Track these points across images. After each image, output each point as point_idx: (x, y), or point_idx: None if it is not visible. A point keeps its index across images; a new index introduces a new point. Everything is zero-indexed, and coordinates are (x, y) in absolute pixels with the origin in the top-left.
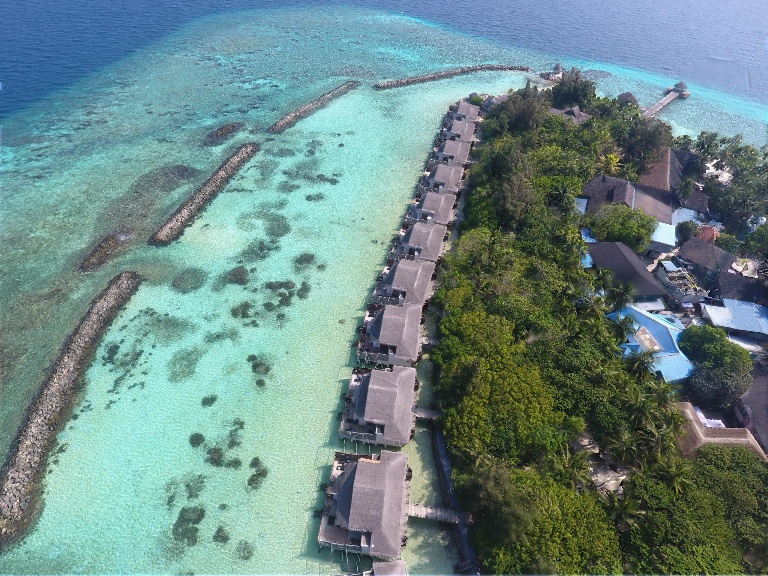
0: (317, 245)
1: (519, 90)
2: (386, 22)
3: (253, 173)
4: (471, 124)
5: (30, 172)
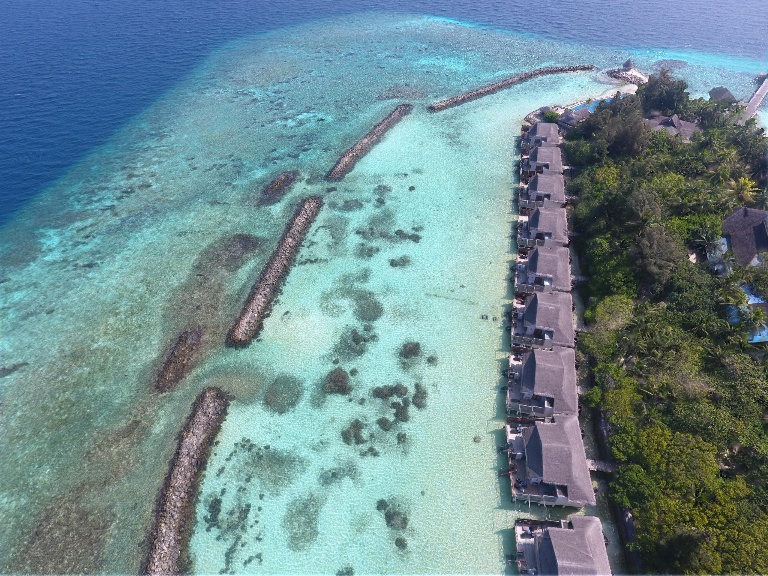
0: (419, 329)
1: (608, 103)
2: (420, 27)
3: (323, 236)
4: (556, 149)
5: (80, 260)
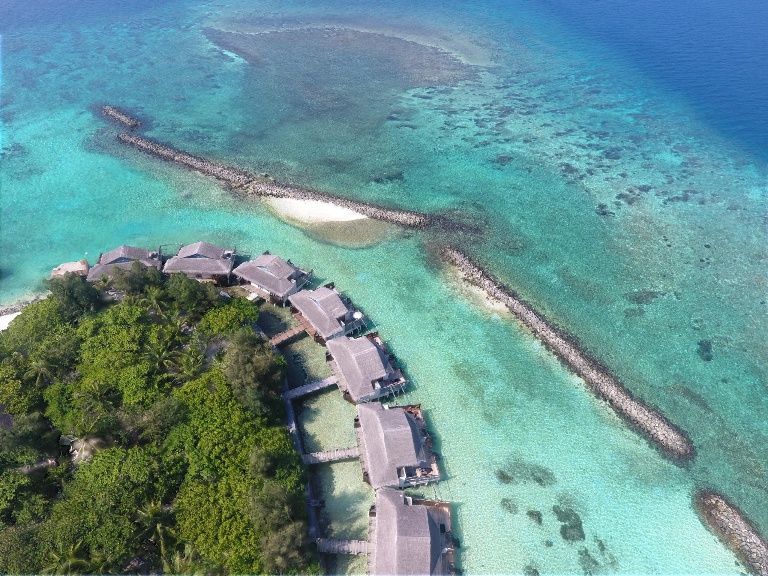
0: None
1: None
2: None
3: None
4: None
5: None
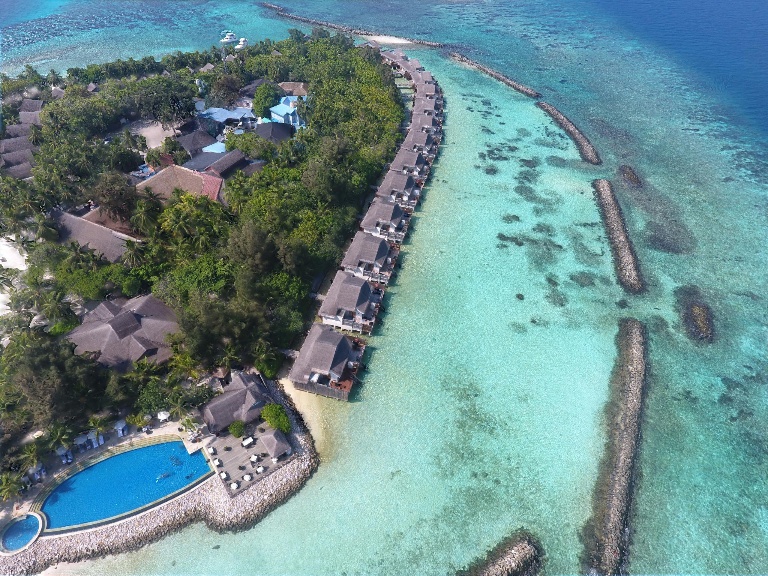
0: (488, 180)
1: (226, 312)
2: None
3: (593, 245)
4: (328, 306)
5: None
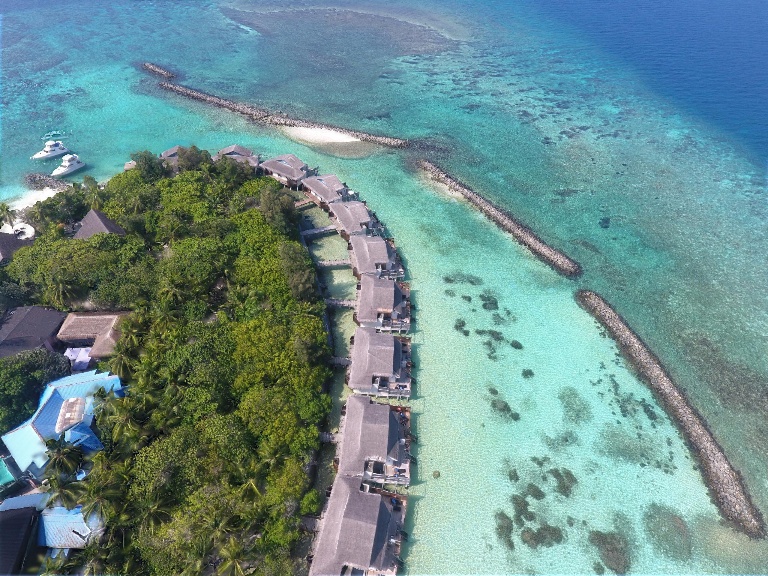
0: None
1: None
2: None
3: None
4: None
5: None
